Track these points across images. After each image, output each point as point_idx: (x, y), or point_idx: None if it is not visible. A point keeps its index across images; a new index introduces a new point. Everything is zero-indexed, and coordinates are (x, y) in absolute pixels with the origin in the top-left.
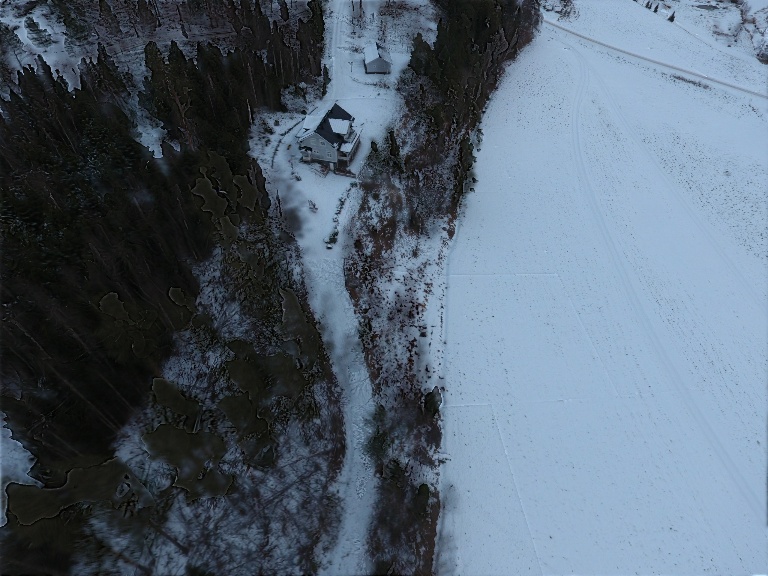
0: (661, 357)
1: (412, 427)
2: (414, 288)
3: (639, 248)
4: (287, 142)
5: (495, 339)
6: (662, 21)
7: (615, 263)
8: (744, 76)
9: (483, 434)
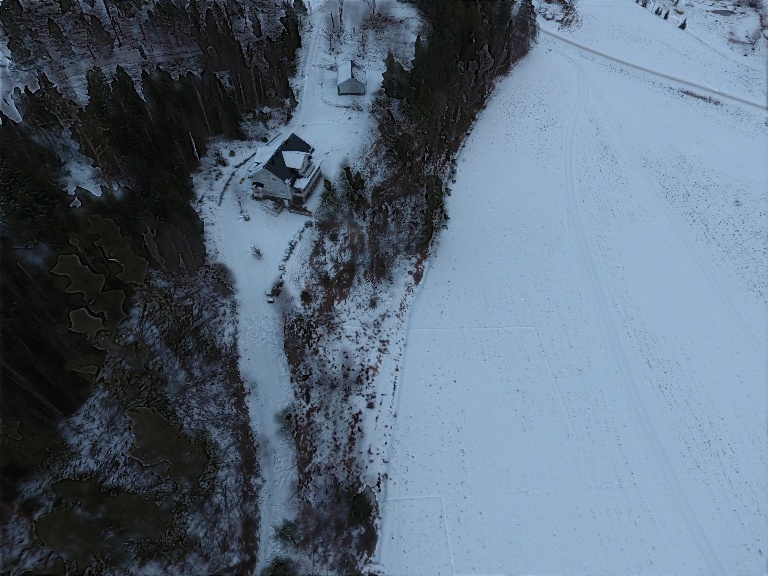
0: (648, 434)
1: (342, 529)
2: (367, 347)
3: (631, 295)
4: (241, 175)
5: (454, 411)
6: (672, 29)
7: (602, 314)
8: (760, 90)
9: (427, 537)
